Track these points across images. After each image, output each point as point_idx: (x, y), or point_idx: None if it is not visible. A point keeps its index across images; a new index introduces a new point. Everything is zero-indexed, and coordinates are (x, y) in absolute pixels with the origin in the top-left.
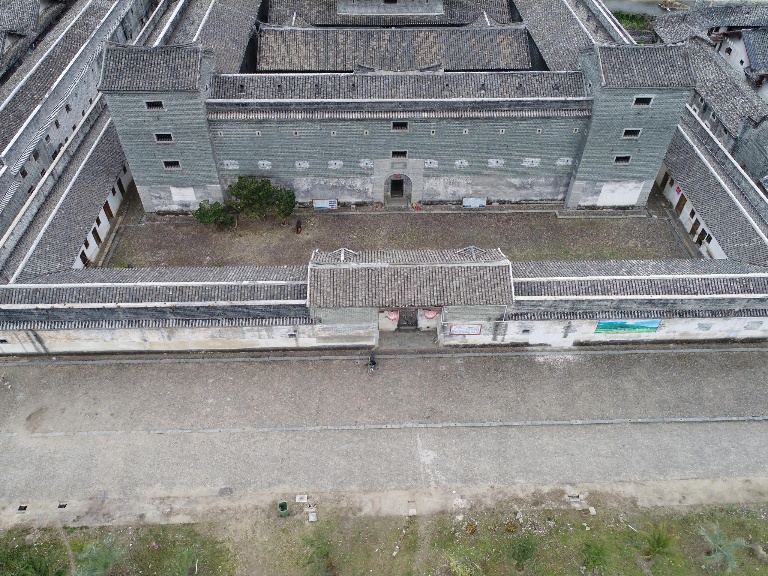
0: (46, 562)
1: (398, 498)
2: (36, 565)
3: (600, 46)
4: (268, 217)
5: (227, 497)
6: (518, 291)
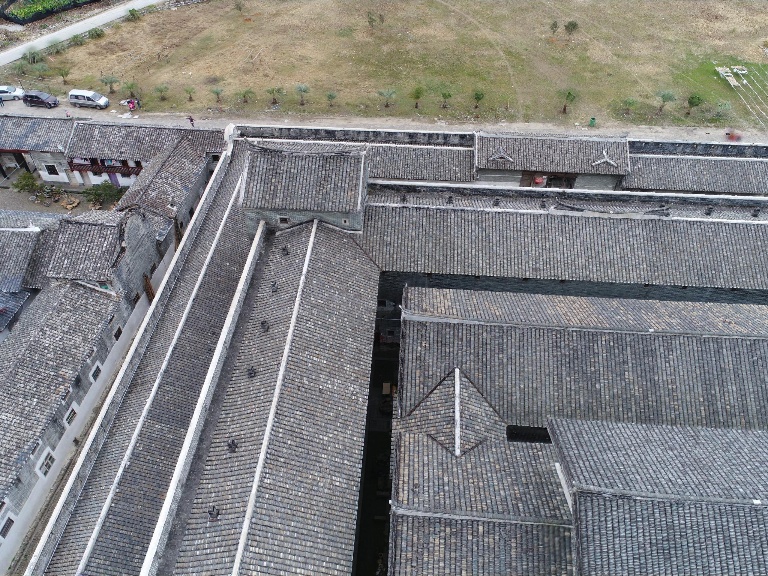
0: None
1: (534, 127)
2: (695, 98)
3: None
4: None
5: (624, 131)
6: None
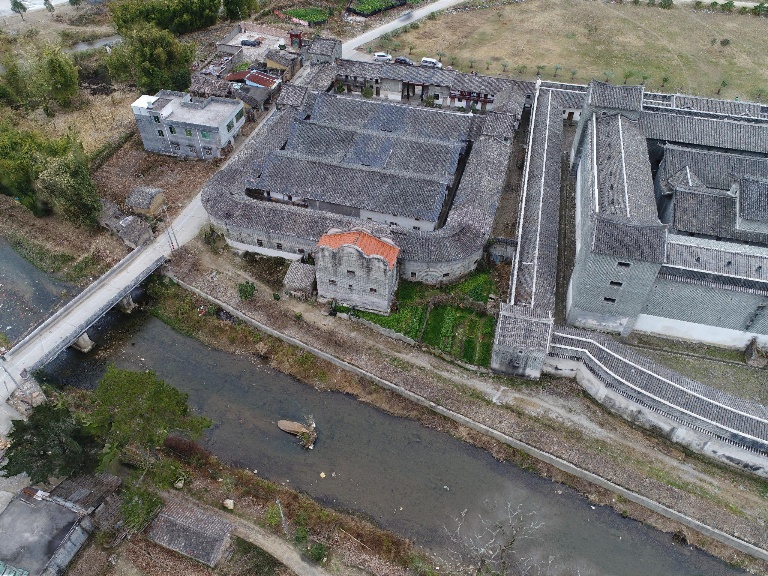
0: None
1: None
2: None
3: None
4: None
5: None
6: None
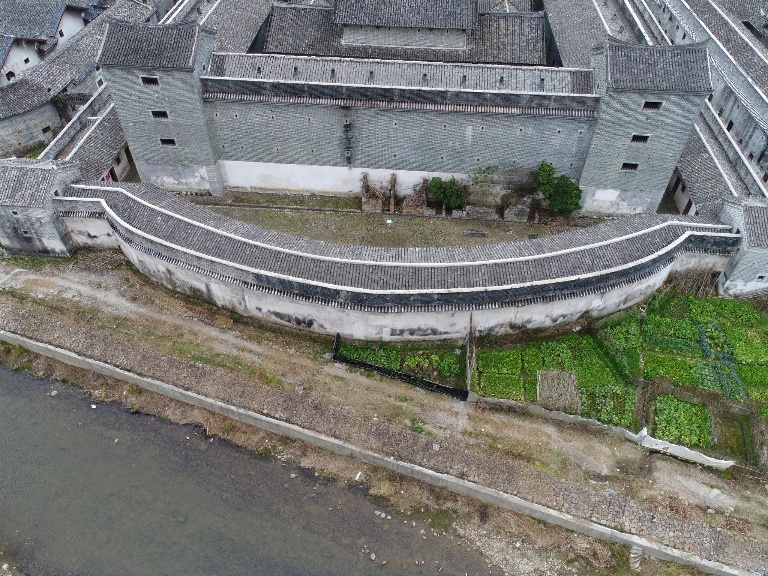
0: None
1: None
2: None
3: None
4: None
5: None
6: None
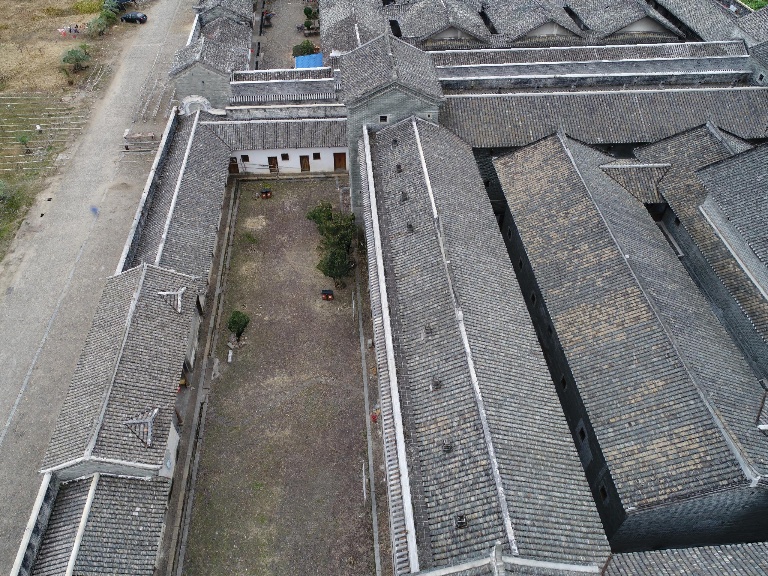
0: (3, 218)
1: None
2: None
3: (493, 566)
4: (352, 270)
5: (4, 292)
6: (80, 492)
